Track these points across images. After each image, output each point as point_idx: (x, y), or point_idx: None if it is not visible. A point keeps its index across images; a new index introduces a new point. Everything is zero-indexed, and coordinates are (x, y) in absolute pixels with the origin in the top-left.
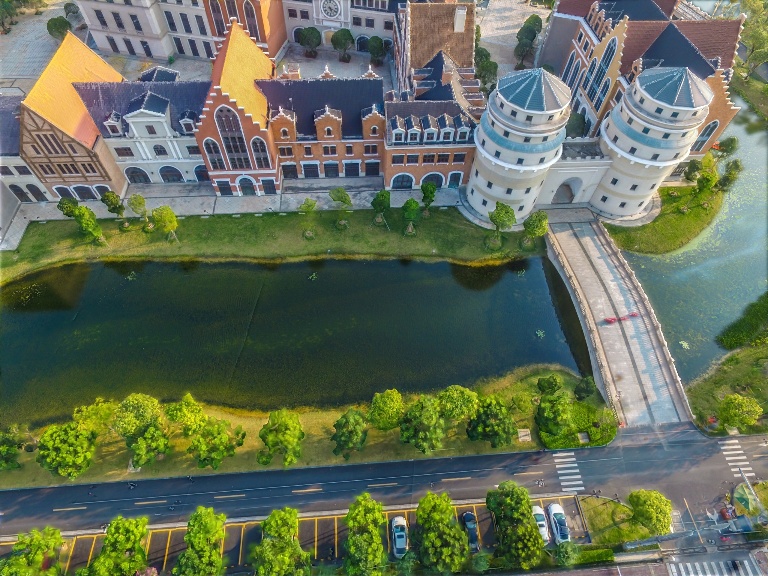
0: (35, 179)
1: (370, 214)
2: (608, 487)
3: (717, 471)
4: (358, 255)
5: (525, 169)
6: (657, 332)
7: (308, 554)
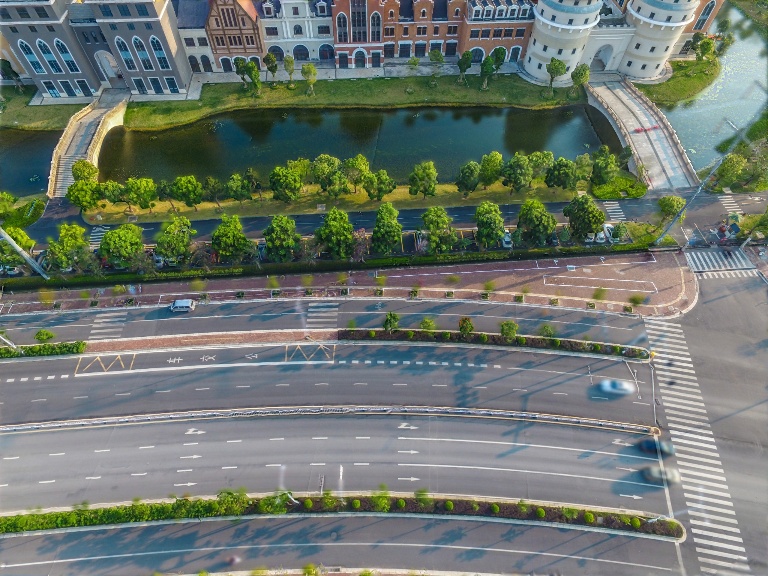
0: (209, 50)
1: (453, 78)
2: (642, 218)
3: (717, 210)
4: (447, 103)
5: (574, 28)
6: (673, 137)
7: (454, 229)
